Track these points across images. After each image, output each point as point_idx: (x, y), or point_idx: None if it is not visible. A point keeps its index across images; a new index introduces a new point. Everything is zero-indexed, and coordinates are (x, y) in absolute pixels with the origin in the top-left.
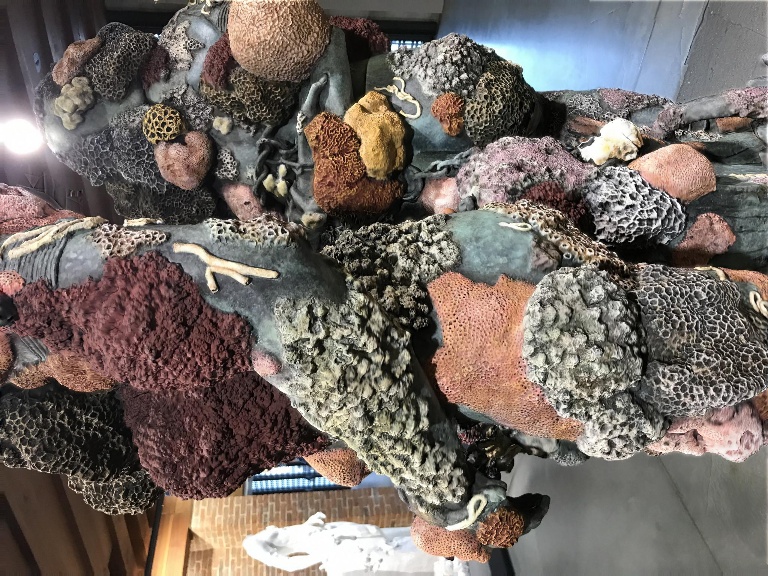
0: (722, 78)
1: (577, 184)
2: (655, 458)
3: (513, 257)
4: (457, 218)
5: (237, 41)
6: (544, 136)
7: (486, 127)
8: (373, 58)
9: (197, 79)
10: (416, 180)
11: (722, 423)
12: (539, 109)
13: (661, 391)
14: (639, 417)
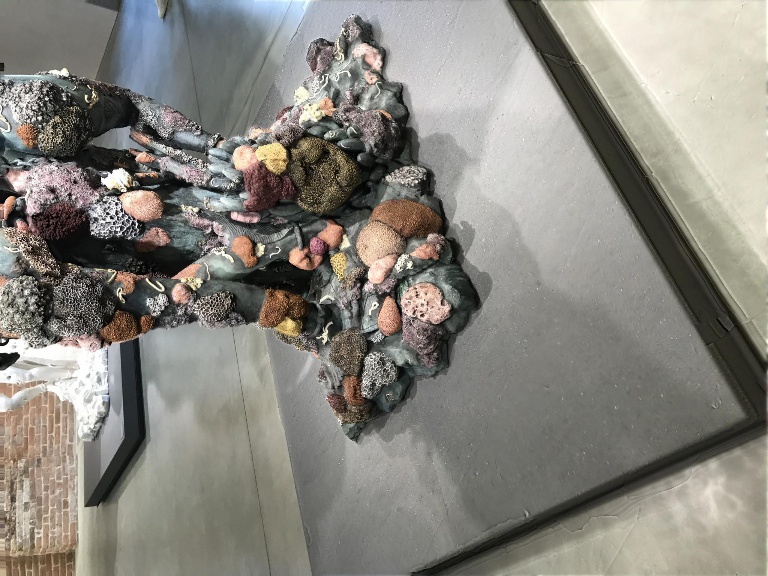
0: (293, 82)
1: (83, 205)
2: None
3: (5, 265)
4: None
5: None
6: (126, 124)
7: (51, 148)
8: None
9: None
10: (3, 168)
11: (83, 339)
12: (116, 115)
13: (54, 327)
14: (43, 336)
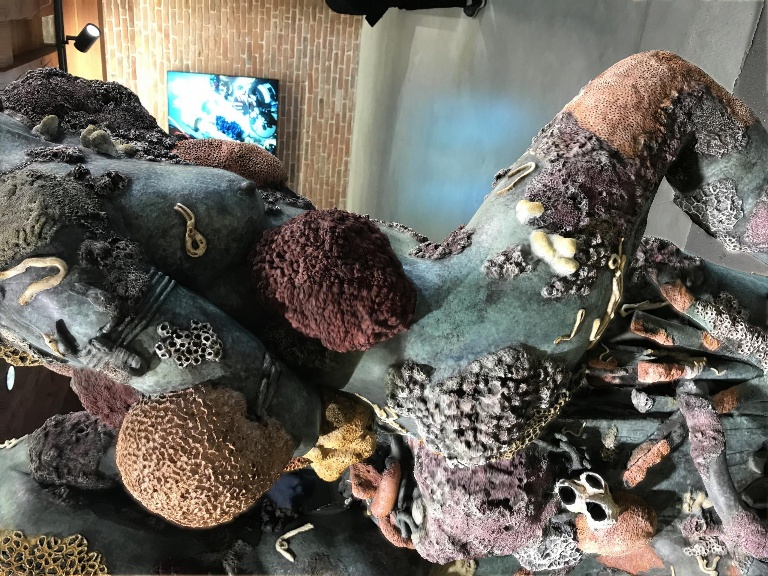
0: None
1: None
2: (644, 9)
3: None
4: None
5: None
6: None
7: None
8: (370, 355)
9: None
10: None
11: None
12: None
13: None
14: None
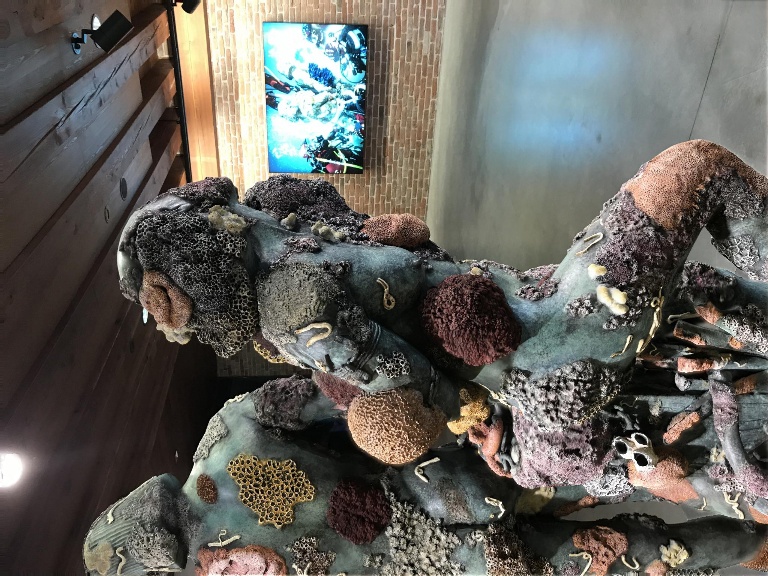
0: None
1: None
2: None
3: None
4: (468, 574)
5: None
6: None
7: None
8: (491, 364)
9: None
10: None
11: None
12: None
13: None
14: None
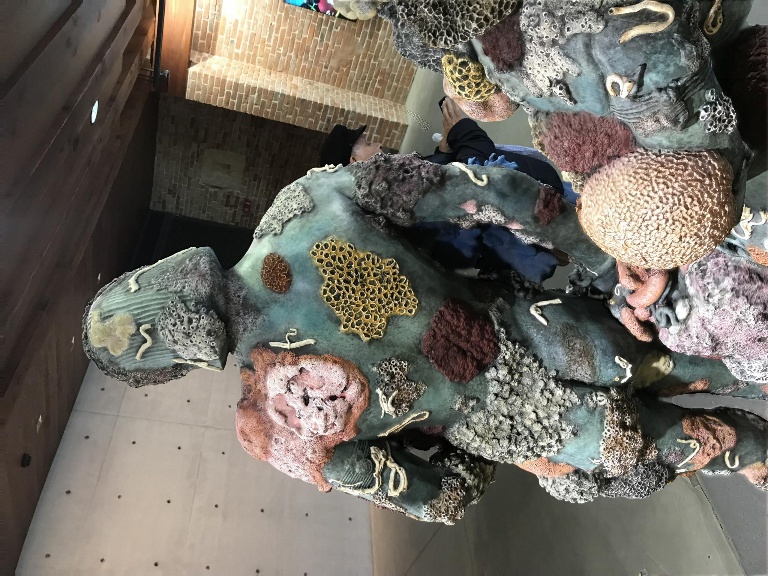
0: None
1: None
2: None
3: None
4: (578, 439)
5: (587, 225)
6: None
7: None
8: None
9: (539, 106)
10: None
11: None
12: None
13: None
14: None
